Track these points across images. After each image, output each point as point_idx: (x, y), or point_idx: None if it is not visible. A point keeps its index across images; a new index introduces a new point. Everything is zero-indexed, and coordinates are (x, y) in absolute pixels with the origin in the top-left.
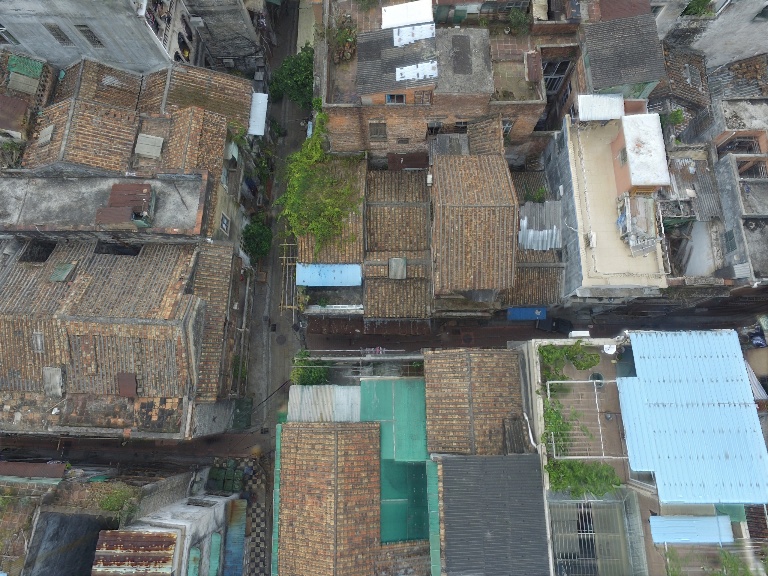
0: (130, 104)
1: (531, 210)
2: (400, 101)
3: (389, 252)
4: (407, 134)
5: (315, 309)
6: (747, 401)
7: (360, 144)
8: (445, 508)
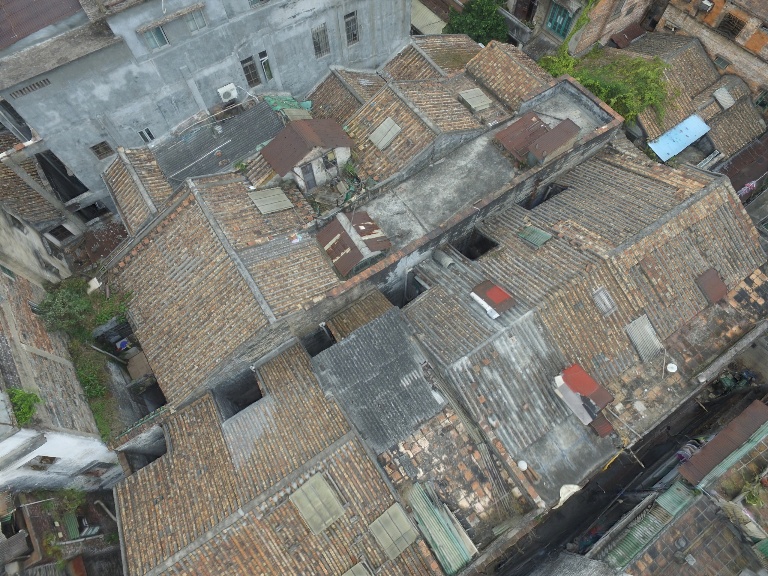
0: None
1: None
2: None
3: (700, 94)
4: None
5: None
6: None
7: (598, 32)
8: None
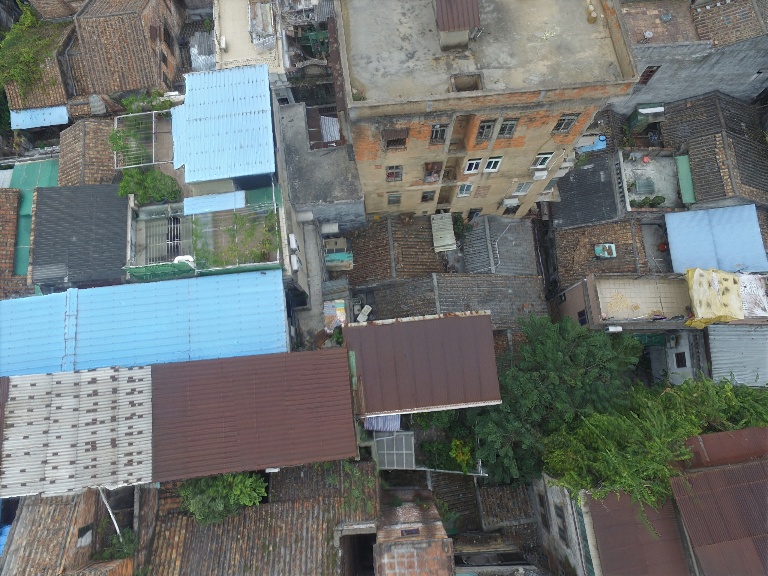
0: None
1: (200, 39)
2: None
3: (93, 94)
4: None
5: (35, 151)
6: (265, 109)
7: (63, 6)
8: (37, 222)
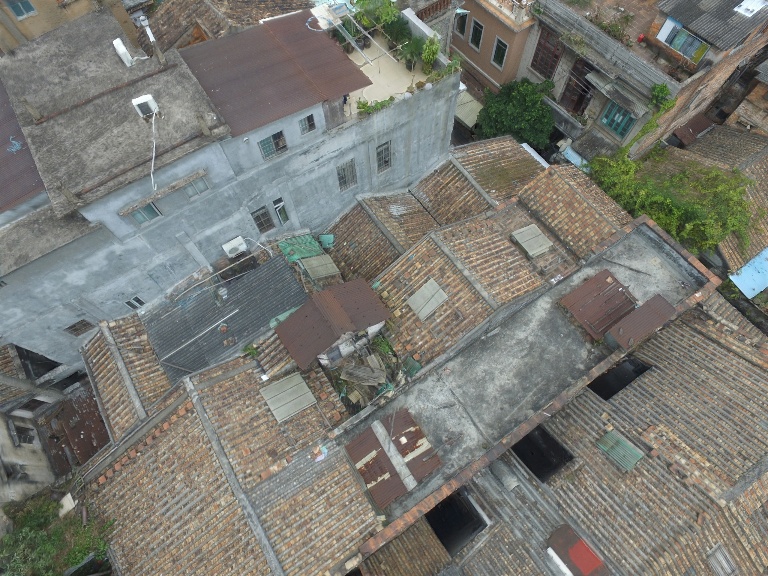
0: (431, 223)
1: None
2: (739, 44)
3: None
4: (710, 91)
5: None
6: None
7: None
8: None
